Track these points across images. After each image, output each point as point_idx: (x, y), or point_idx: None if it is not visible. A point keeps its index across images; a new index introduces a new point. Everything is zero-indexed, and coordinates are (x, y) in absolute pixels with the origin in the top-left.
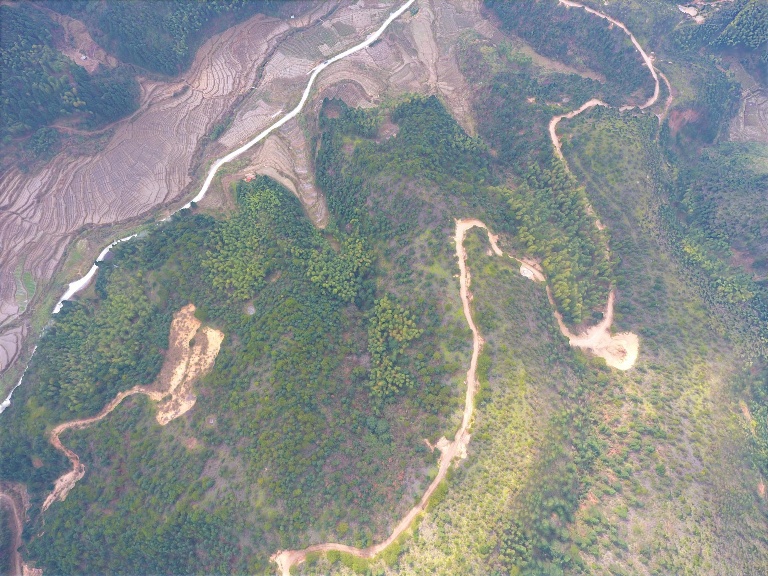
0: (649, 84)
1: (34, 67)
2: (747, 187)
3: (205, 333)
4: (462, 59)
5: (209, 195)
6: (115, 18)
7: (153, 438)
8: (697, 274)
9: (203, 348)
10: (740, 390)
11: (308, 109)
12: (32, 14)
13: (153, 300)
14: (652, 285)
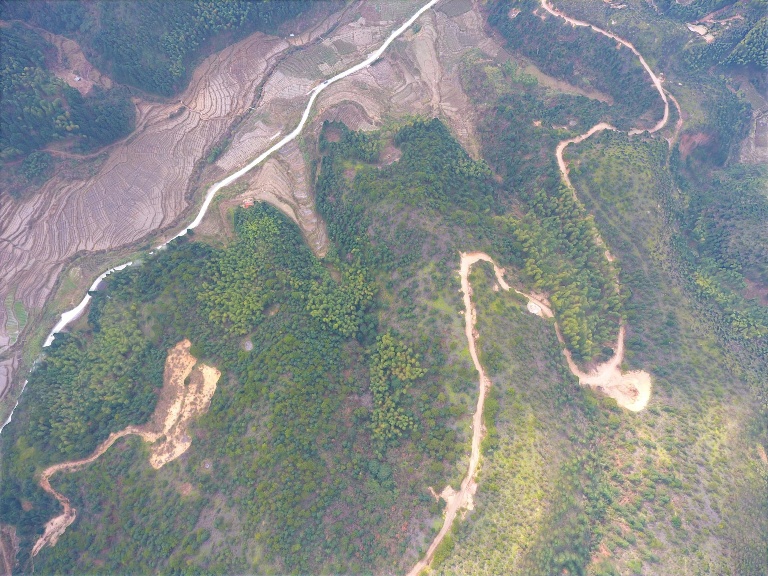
0: (658, 106)
1: (26, 90)
2: (760, 214)
3: (201, 371)
4: (466, 79)
5: (206, 221)
6: (109, 39)
7: (146, 484)
8: (711, 309)
9: (199, 387)
10: (757, 433)
11: (308, 131)
12: (24, 34)
13: (147, 334)
14: (664, 321)
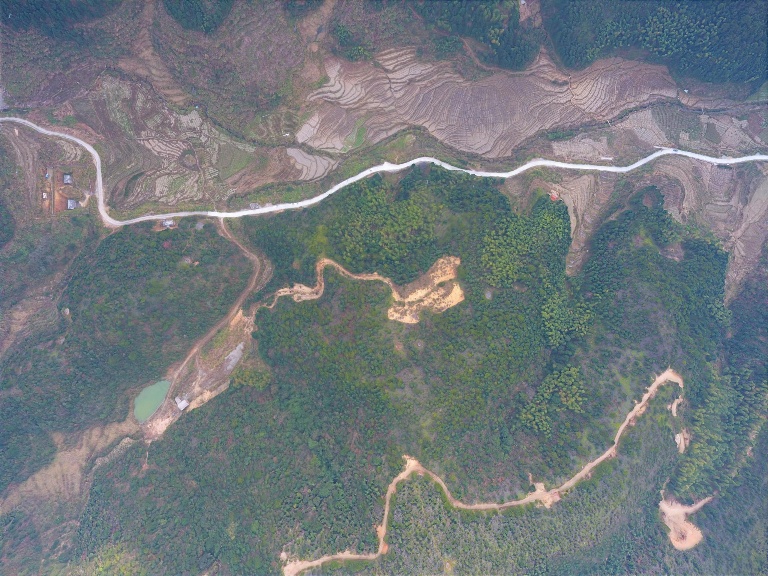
0: None
1: None
2: None
3: (454, 286)
4: None
5: (516, 180)
6: None
7: (381, 323)
8: None
9: (446, 294)
10: None
11: (634, 179)
12: None
13: (436, 231)
14: (744, 520)
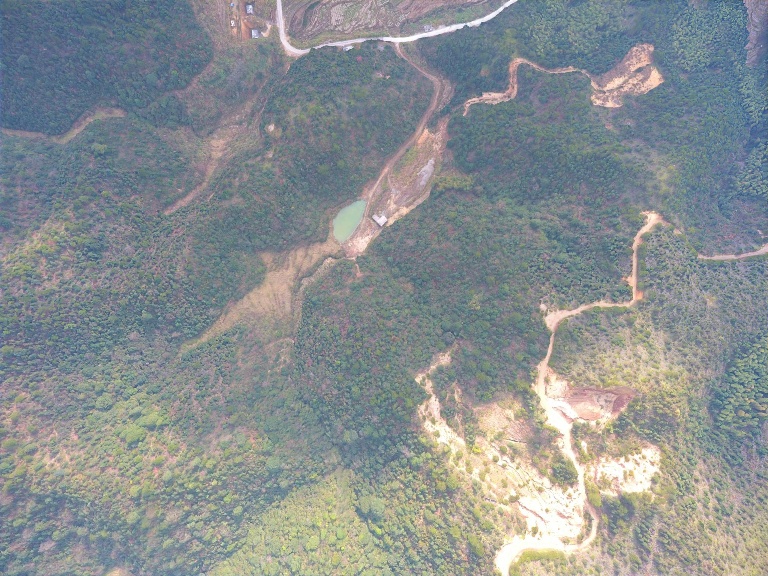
0: None
1: None
2: None
3: (651, 70)
4: None
5: None
6: None
7: None
8: None
9: (645, 78)
10: None
11: None
12: None
13: None
14: None
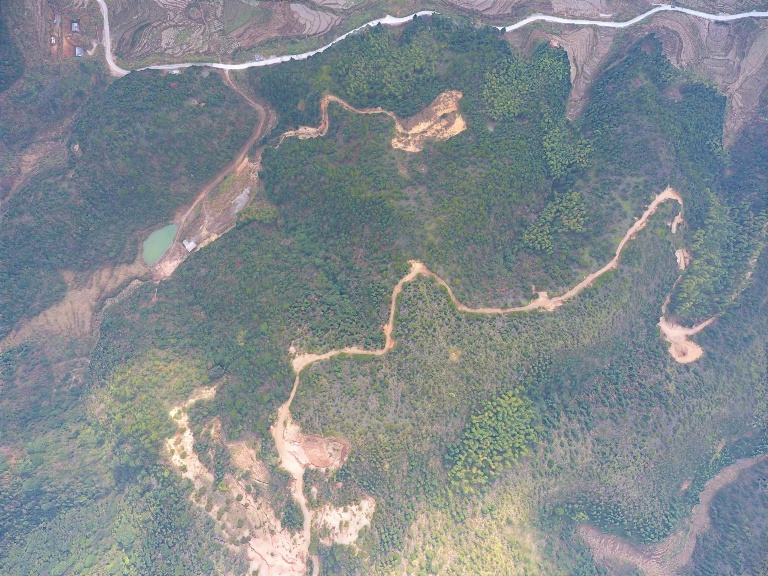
0: None
1: None
2: None
3: (456, 117)
4: None
5: (516, 33)
6: None
7: (385, 148)
8: None
9: (448, 125)
10: (731, 433)
11: (632, 31)
12: None
13: None
14: (744, 335)
